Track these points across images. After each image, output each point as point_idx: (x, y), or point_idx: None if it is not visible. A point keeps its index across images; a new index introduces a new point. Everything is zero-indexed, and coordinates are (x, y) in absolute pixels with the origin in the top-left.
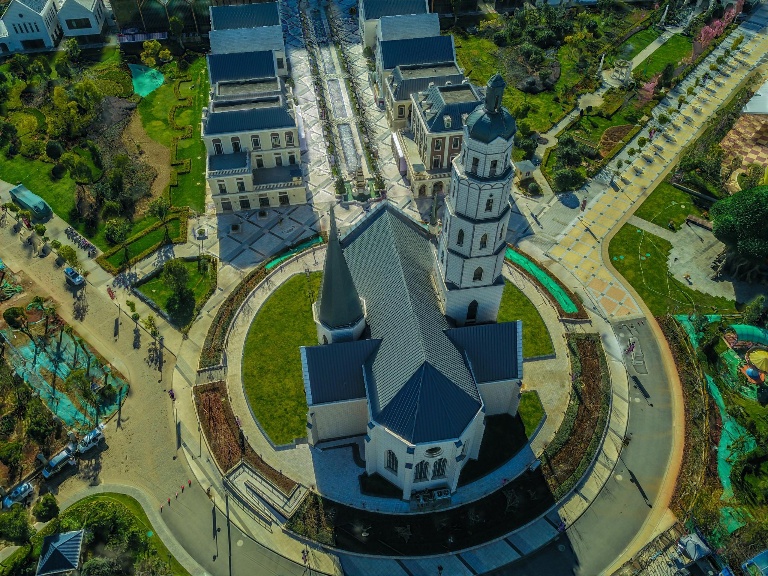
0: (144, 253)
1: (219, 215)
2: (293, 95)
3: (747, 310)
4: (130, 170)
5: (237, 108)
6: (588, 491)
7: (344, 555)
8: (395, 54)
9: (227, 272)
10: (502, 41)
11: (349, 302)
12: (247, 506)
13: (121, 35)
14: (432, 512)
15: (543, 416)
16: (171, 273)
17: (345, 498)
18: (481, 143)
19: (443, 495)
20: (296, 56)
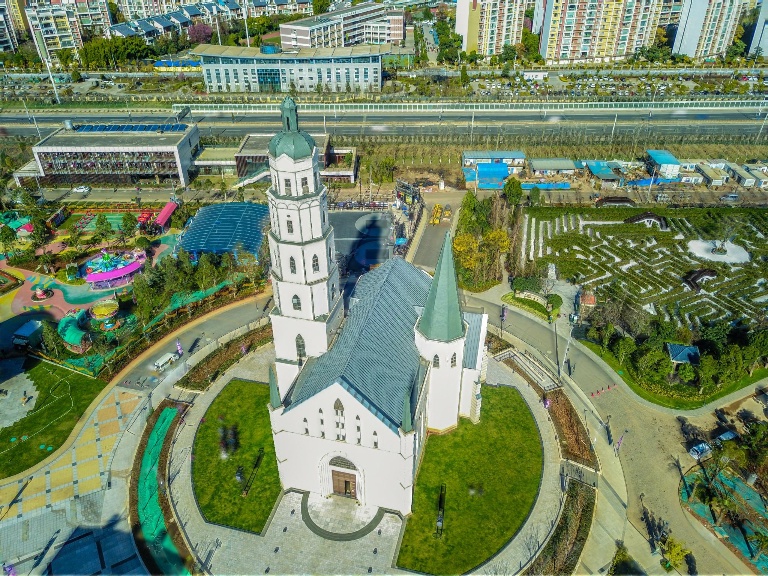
0: None
1: None
2: None
3: None
4: None
5: None
6: None
7: None
8: None
9: None
10: None
11: None
12: None
13: None
14: None
15: None
16: None
17: None
18: None
19: None
20: None
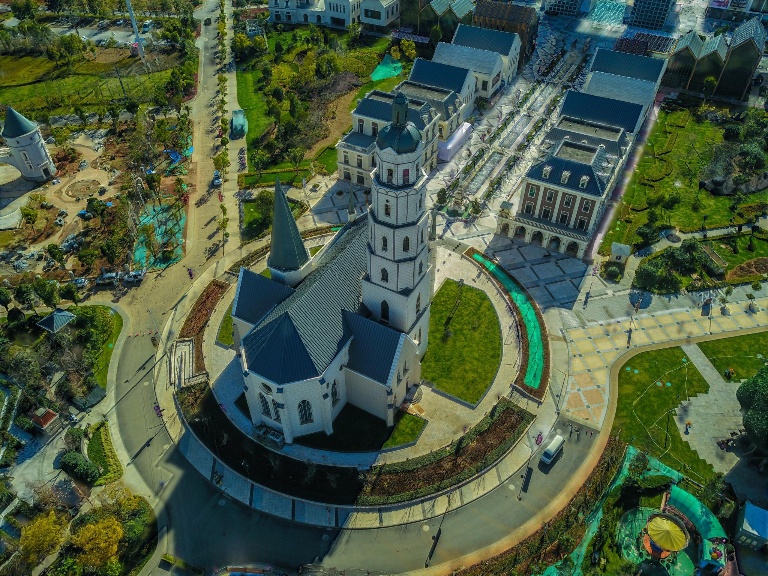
0: (269, 183)
1: (339, 180)
2: (482, 116)
3: (705, 482)
4: (313, 126)
5: (388, 101)
6: (389, 517)
7: (189, 432)
8: (577, 106)
9: (306, 220)
10: (731, 135)
11: (285, 250)
12: (170, 366)
13: (396, 31)
14: (262, 445)
15: (412, 441)
16: (260, 199)
17: (223, 399)
18: (378, 148)
19: (274, 436)
20: (518, 87)
